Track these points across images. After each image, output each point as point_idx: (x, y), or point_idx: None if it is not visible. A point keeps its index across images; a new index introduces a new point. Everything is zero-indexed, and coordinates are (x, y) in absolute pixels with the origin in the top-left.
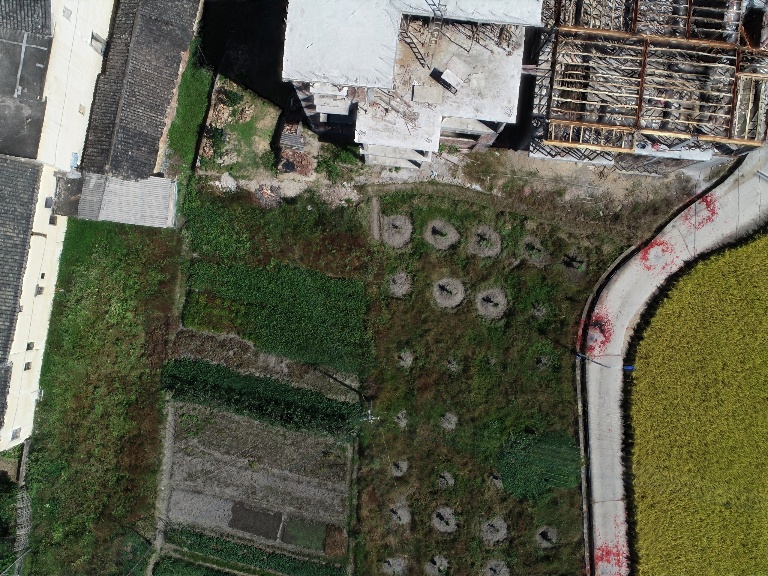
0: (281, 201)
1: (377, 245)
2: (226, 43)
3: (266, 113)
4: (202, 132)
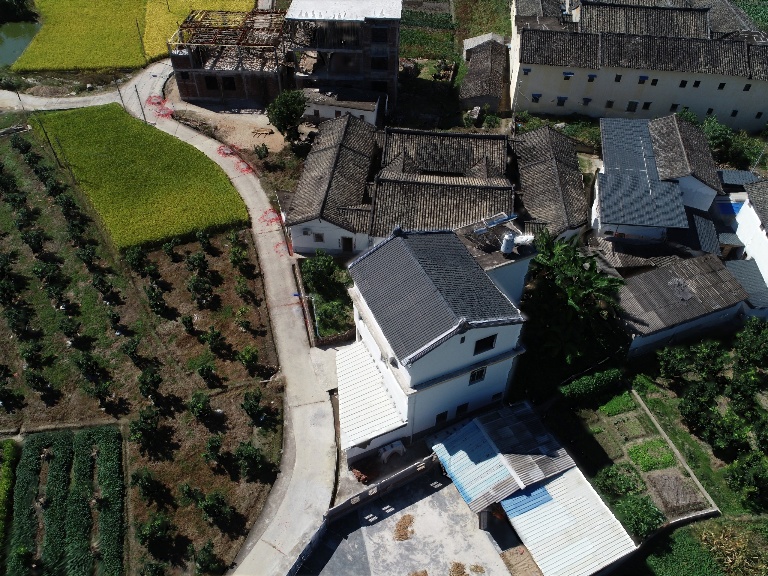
0: None
1: None
2: None
3: None
4: (456, 74)
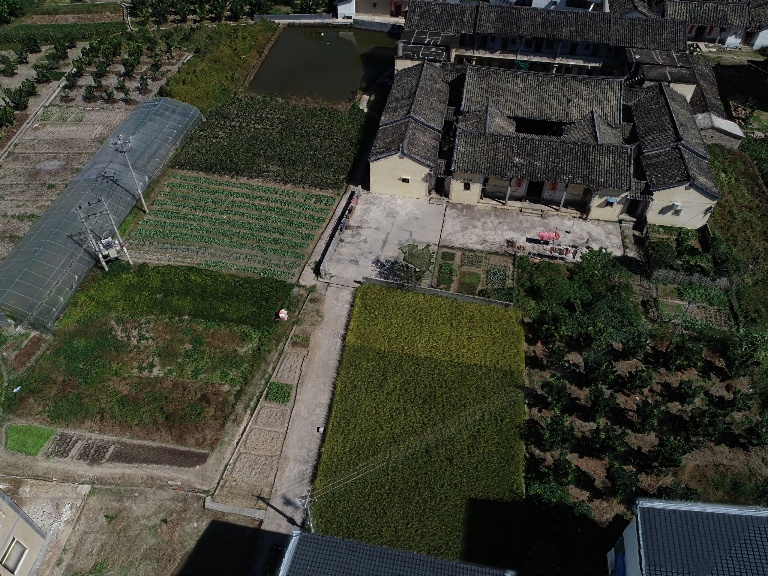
0: None
1: None
2: (726, 94)
3: (763, 114)
4: None
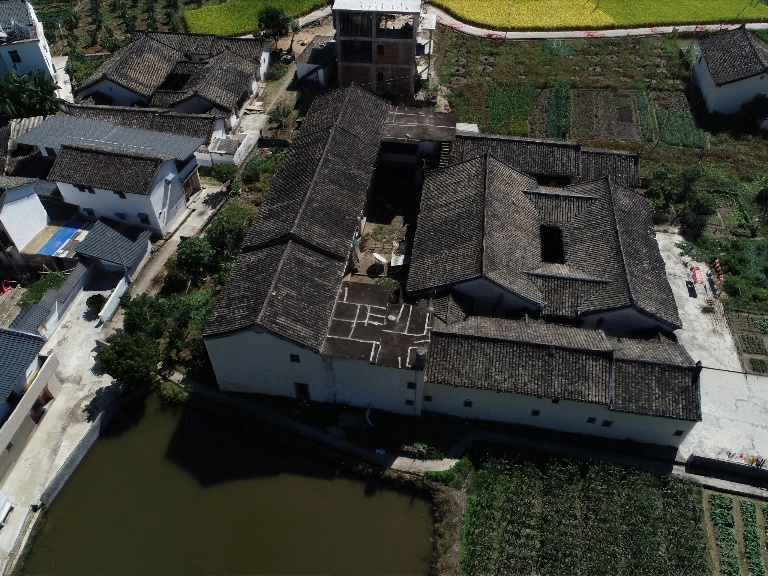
0: (451, 107)
1: (467, 83)
2: None
3: None
4: None
